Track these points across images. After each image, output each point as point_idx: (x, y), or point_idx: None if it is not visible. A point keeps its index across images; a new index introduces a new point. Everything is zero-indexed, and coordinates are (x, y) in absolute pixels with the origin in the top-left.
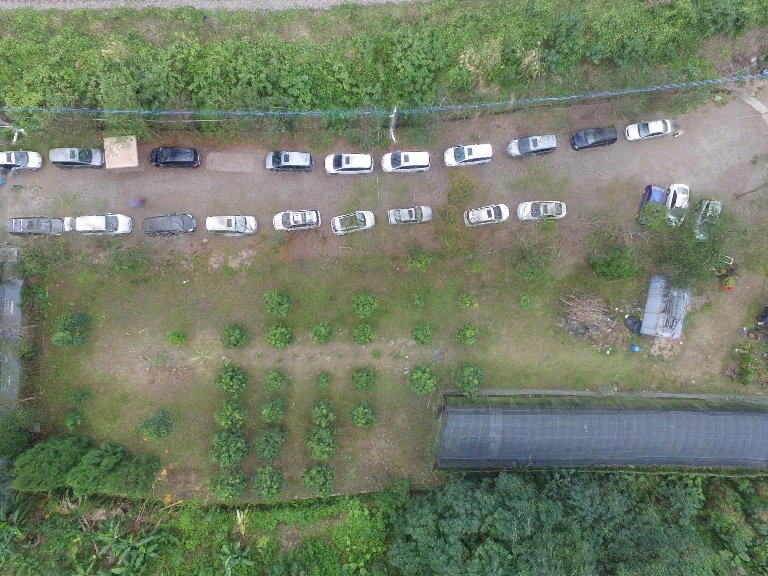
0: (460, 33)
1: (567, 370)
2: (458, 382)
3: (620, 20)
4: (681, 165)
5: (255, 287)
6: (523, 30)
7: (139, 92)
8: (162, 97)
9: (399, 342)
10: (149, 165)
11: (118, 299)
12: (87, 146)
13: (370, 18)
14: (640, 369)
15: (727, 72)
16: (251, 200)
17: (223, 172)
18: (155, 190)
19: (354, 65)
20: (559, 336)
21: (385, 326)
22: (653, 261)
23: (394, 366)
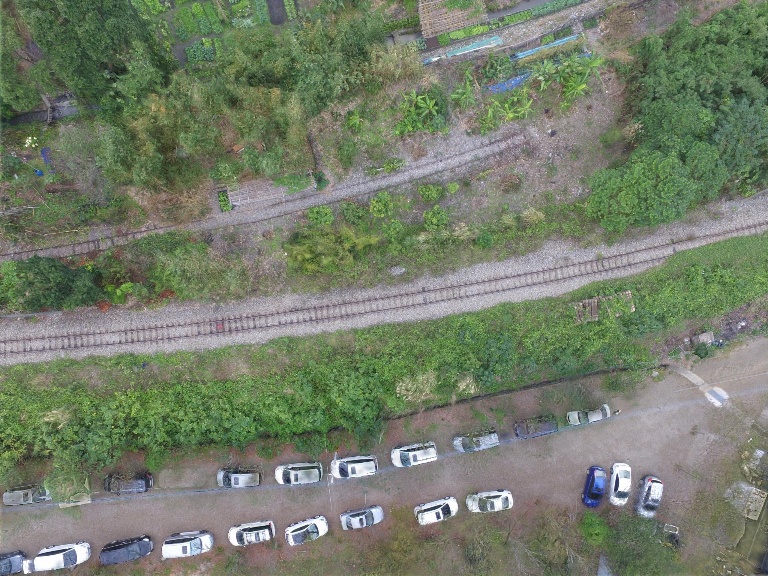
0: (395, 362)
1: None
2: None
3: (551, 336)
4: (623, 441)
5: None
6: (457, 352)
7: (84, 453)
8: (106, 462)
9: None
10: (103, 488)
11: None
12: (41, 475)
13: (307, 349)
14: None
15: (662, 352)
16: (206, 514)
17: (176, 488)
18: (111, 512)
19: (294, 398)
20: None
21: None
22: None
23: None
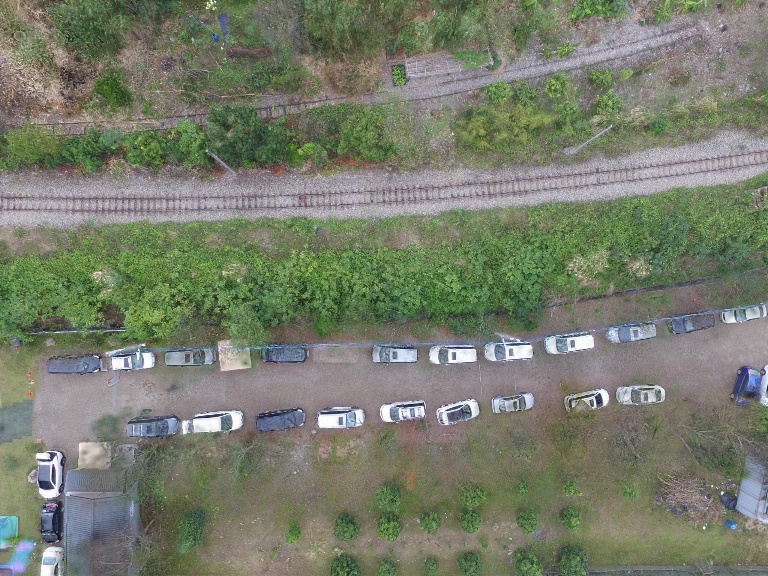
0: (568, 239)
1: (665, 546)
2: (564, 568)
3: (724, 222)
4: None
5: (363, 475)
6: (629, 234)
7: (259, 310)
8: (283, 318)
9: (503, 525)
10: (258, 359)
11: (231, 490)
12: (197, 342)
13: (478, 223)
14: (735, 543)
15: None
16: (357, 390)
17: (329, 363)
18: (264, 383)
19: (464, 271)
20: (657, 513)
21: (489, 509)
22: (748, 439)
23: (499, 548)
